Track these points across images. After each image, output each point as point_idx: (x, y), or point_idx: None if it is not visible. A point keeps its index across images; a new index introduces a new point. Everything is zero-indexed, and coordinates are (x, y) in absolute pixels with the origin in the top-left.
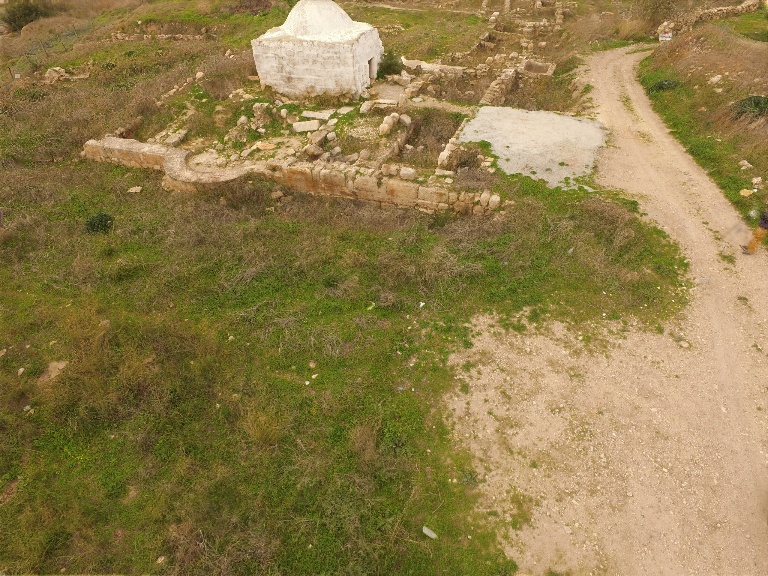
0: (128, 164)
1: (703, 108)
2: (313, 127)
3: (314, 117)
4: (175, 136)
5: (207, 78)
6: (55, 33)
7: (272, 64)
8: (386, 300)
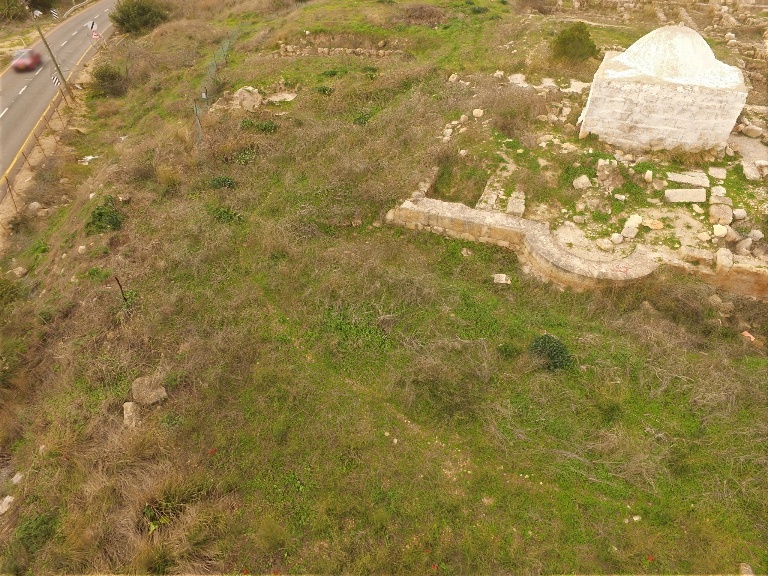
0: (456, 235)
1: None
2: (699, 198)
3: (689, 183)
4: (517, 202)
5: (487, 117)
6: (198, 40)
7: (615, 110)
8: None
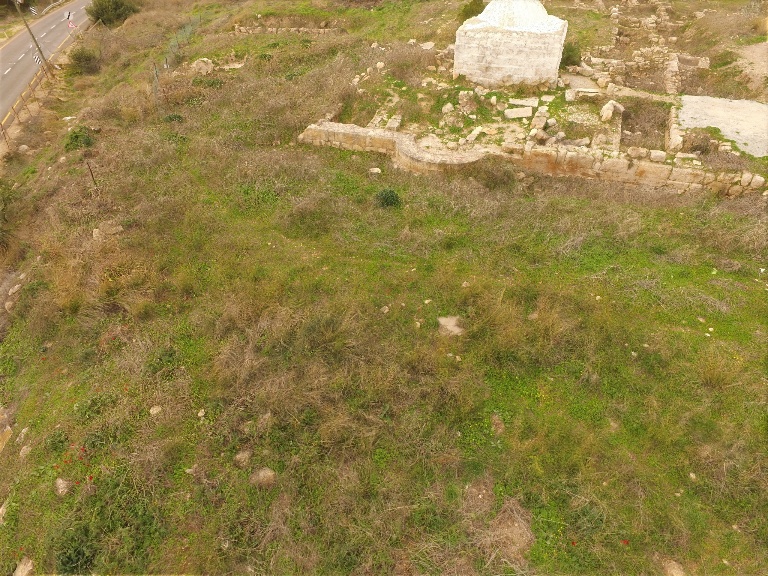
0: (349, 147)
1: None
2: (527, 114)
3: (523, 104)
4: (394, 121)
5: (387, 68)
6: (164, 26)
7: (473, 54)
8: (731, 265)
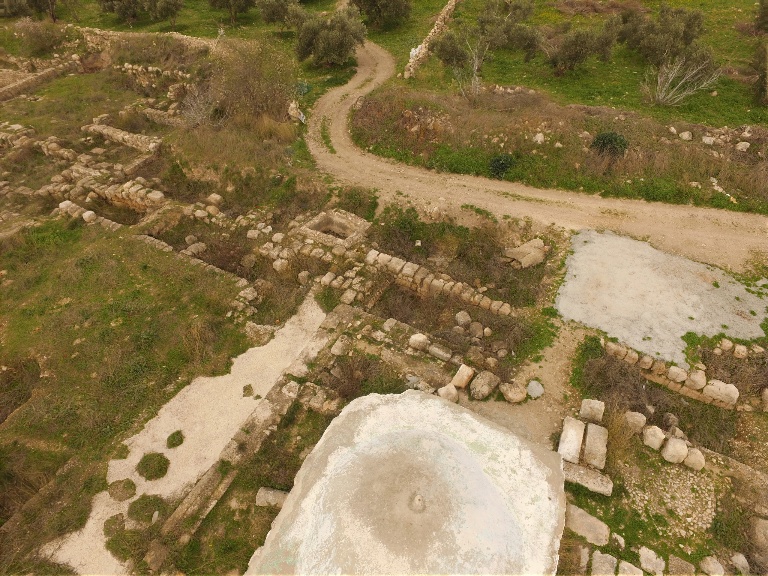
0: None
1: (577, 164)
2: None
3: None
4: None
5: None
6: None
7: None
8: None
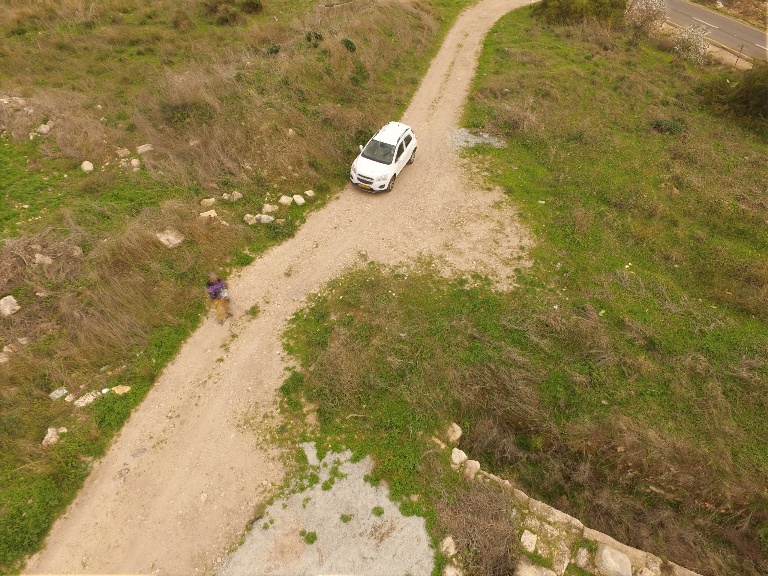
0: None
1: None
2: None
3: None
4: None
5: None
6: None
7: None
8: None
